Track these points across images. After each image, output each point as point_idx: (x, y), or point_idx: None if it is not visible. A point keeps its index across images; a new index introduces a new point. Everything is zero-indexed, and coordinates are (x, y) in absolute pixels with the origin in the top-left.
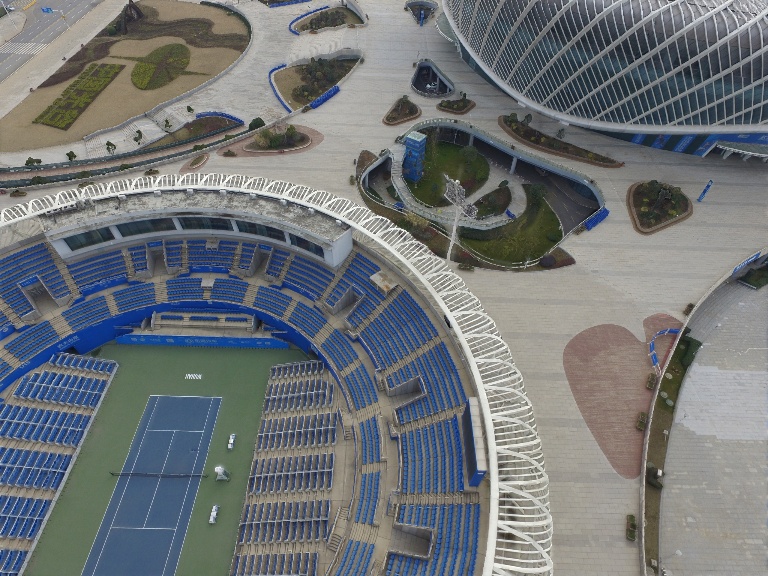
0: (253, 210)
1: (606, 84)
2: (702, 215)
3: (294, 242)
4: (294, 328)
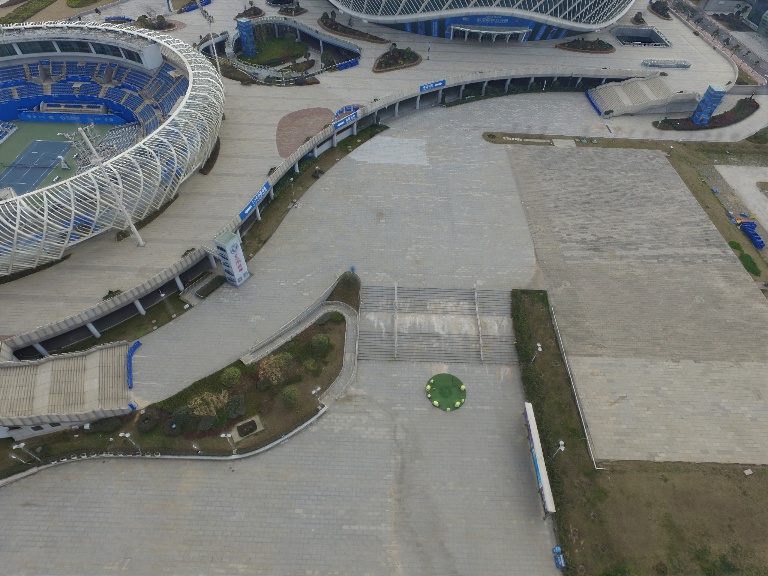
0: (101, 36)
1: None
2: (424, 65)
3: (127, 57)
4: (124, 106)
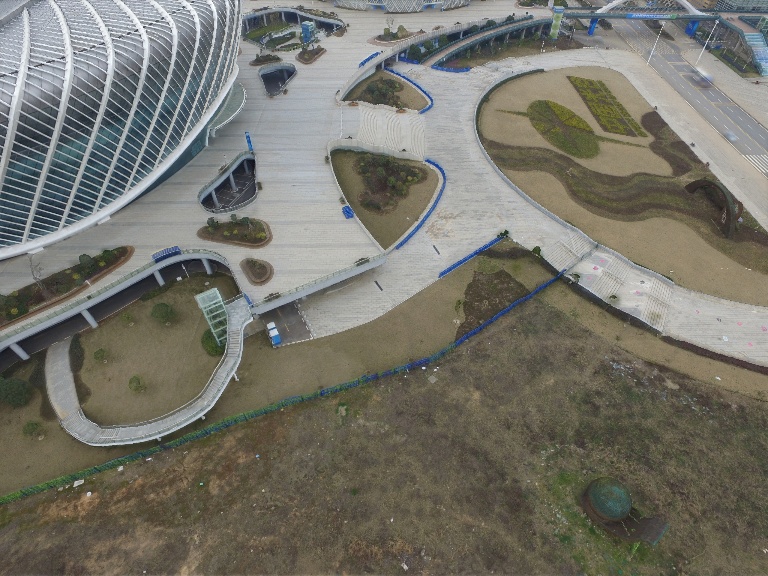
0: None
1: None
2: None
3: None
4: None
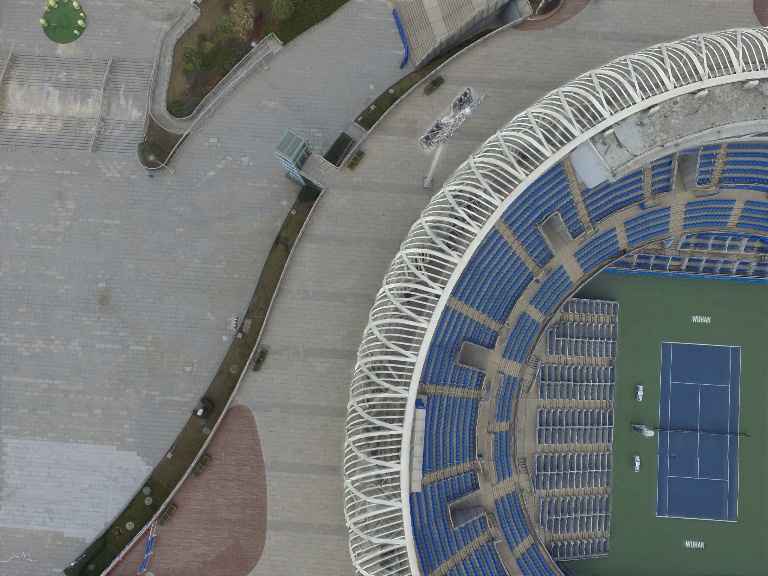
0: None
1: None
2: None
3: None
4: None
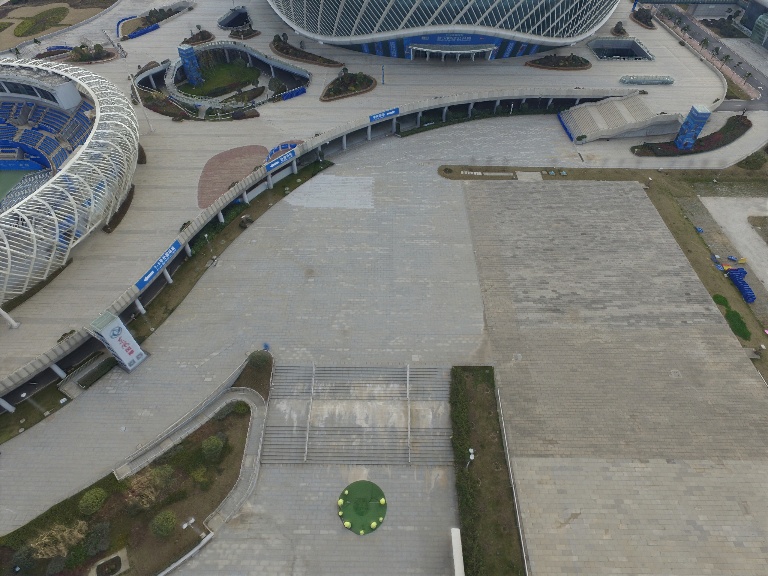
0: (13, 74)
1: (322, 3)
2: (377, 91)
3: (42, 96)
4: (38, 150)
